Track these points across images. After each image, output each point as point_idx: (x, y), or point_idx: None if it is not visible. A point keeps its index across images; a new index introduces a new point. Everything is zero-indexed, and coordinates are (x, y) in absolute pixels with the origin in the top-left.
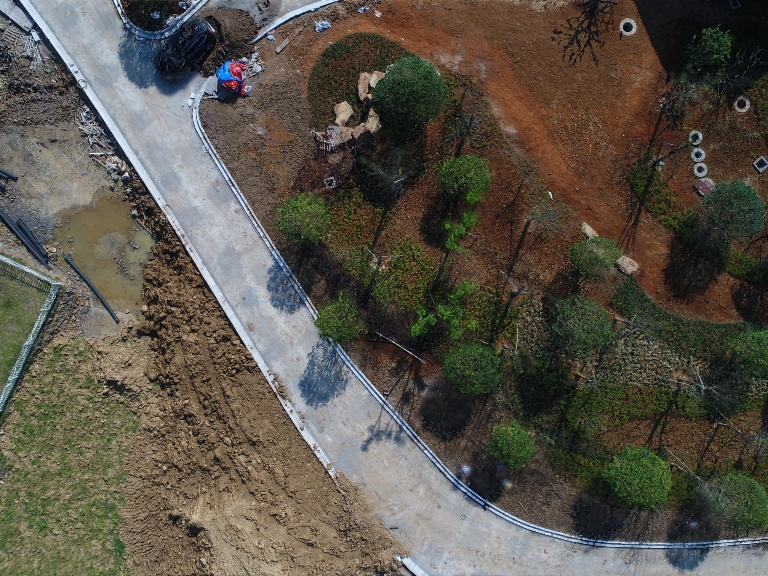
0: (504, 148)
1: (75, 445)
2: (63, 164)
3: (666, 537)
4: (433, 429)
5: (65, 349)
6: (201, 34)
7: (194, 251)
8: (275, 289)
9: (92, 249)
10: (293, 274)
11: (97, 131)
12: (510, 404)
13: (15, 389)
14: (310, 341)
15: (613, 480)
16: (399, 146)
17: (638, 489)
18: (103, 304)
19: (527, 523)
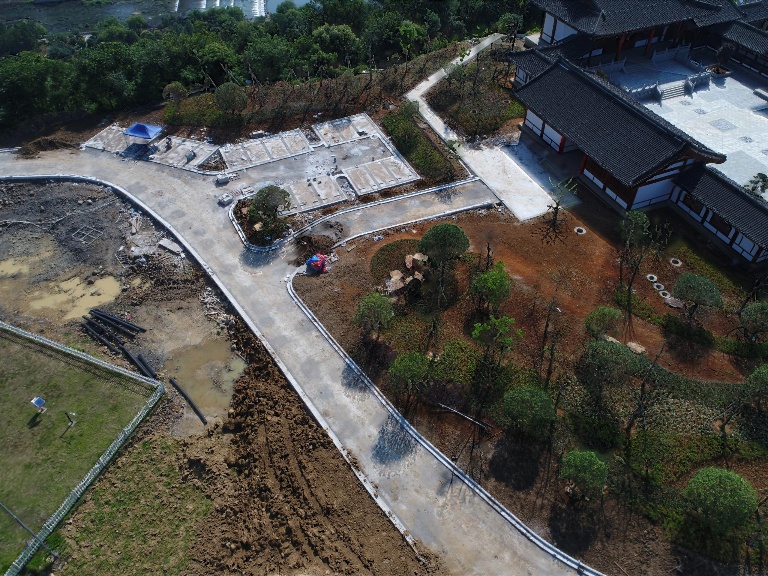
0: (516, 286)
1: (142, 532)
2: (184, 321)
3: None
4: (506, 489)
5: (154, 443)
6: (299, 239)
7: (281, 362)
8: (348, 384)
9: (194, 373)
10: (363, 372)
11: (214, 300)
12: None
13: (98, 477)
14: (380, 421)
15: (695, 491)
16: None
17: (722, 491)
18: (195, 411)
19: None
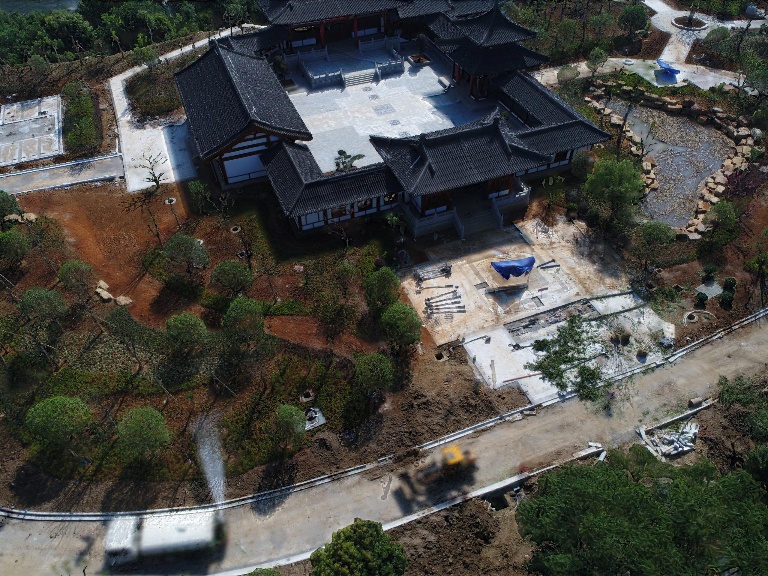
0: (62, 248)
1: None
2: None
3: (100, 507)
4: None
5: None
6: None
7: None
8: None
9: None
10: None
11: None
12: None
13: None
14: None
15: None
16: None
17: (42, 412)
18: None
19: None
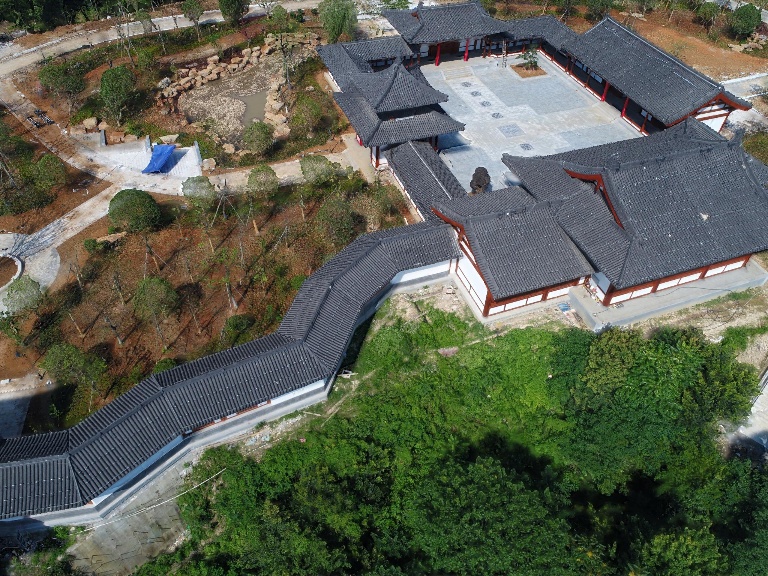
0: None
1: None
2: None
3: None
4: None
5: None
6: None
7: None
8: None
9: None
10: None
11: None
12: None
13: None
14: (734, 8)
15: None
16: (733, 35)
17: None
18: None
19: None
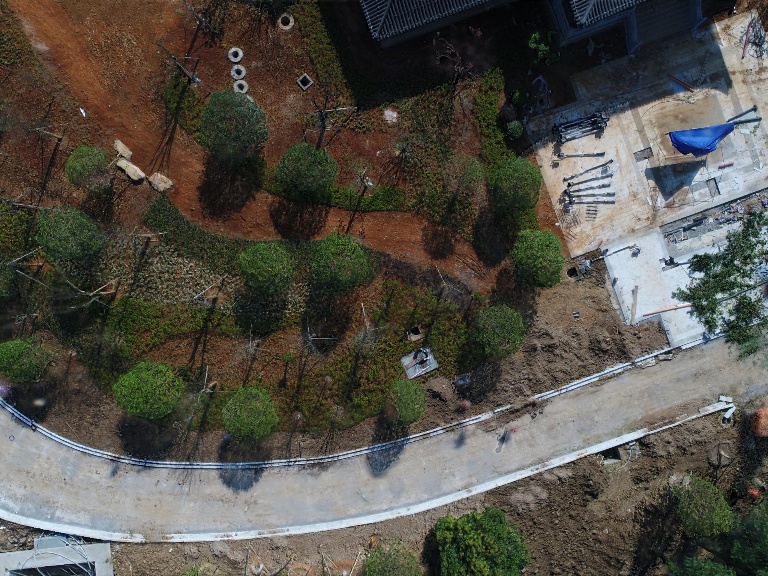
0: (35, 65)
1: None
2: None
3: (217, 457)
4: None
5: None
6: None
7: None
8: None
9: None
10: None
11: None
12: (47, 323)
13: None
14: None
15: (115, 393)
16: None
17: (132, 400)
18: None
19: (75, 443)
